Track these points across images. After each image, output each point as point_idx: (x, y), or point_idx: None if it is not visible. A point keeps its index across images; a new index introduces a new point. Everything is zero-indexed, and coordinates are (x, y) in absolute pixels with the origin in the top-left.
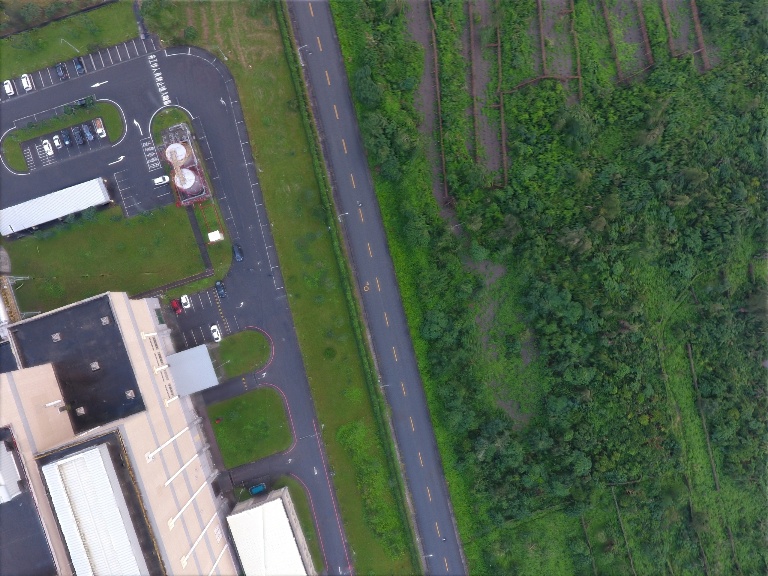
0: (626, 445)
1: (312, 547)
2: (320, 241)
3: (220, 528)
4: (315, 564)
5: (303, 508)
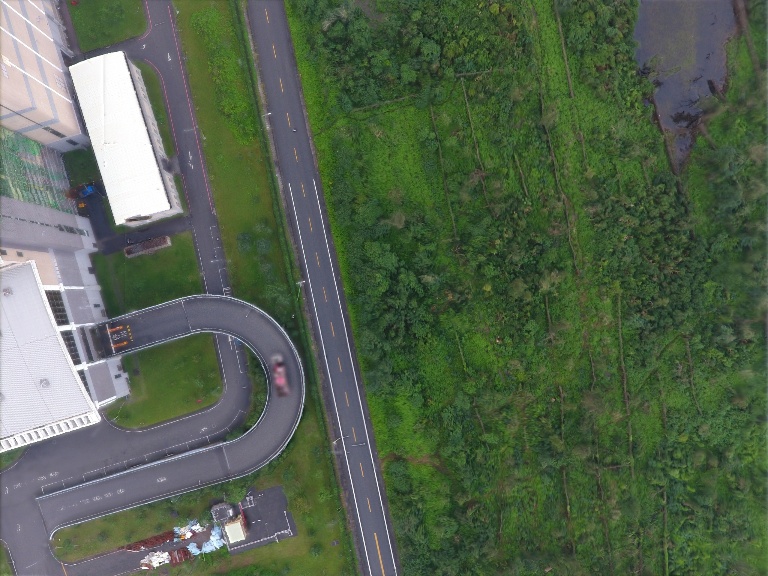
0: (475, 31)
1: (163, 130)
2: None
3: (65, 85)
4: (165, 147)
5: (156, 92)
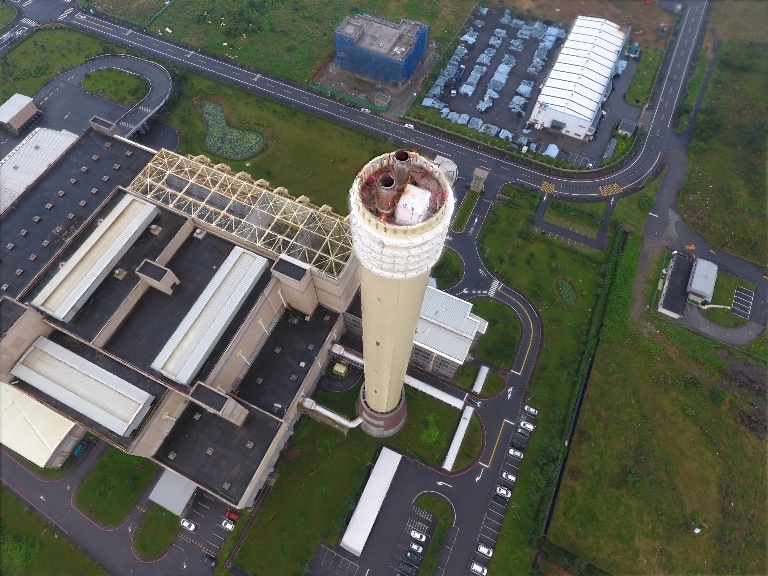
0: None
1: None
2: None
3: None
4: None
5: None
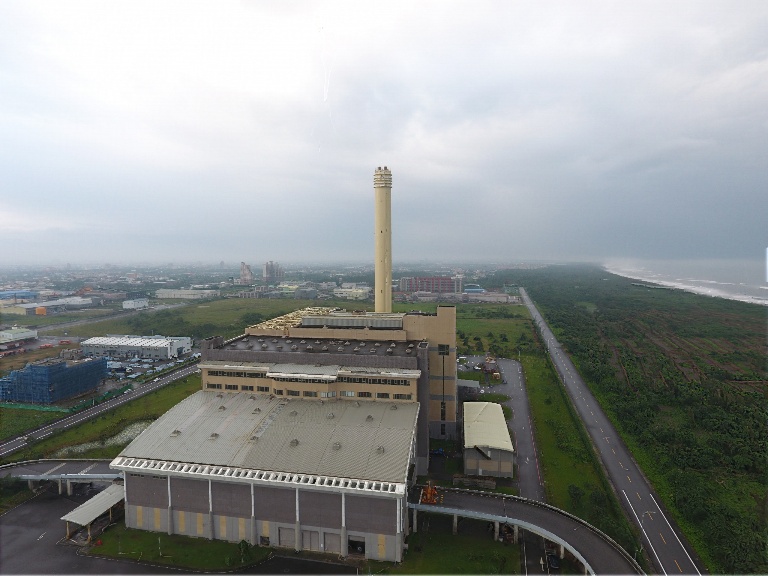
0: None
1: None
2: None
3: None
4: None
5: None
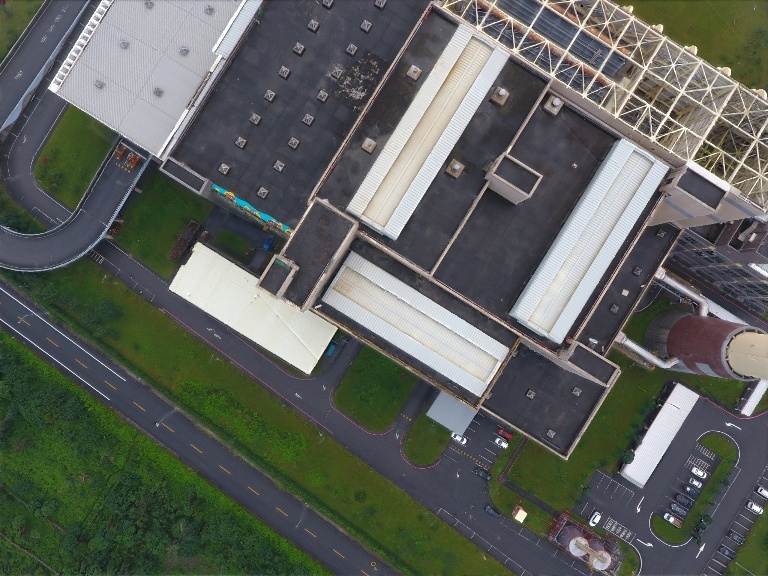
0: None
1: None
2: (438, 573)
3: None
4: None
5: None
